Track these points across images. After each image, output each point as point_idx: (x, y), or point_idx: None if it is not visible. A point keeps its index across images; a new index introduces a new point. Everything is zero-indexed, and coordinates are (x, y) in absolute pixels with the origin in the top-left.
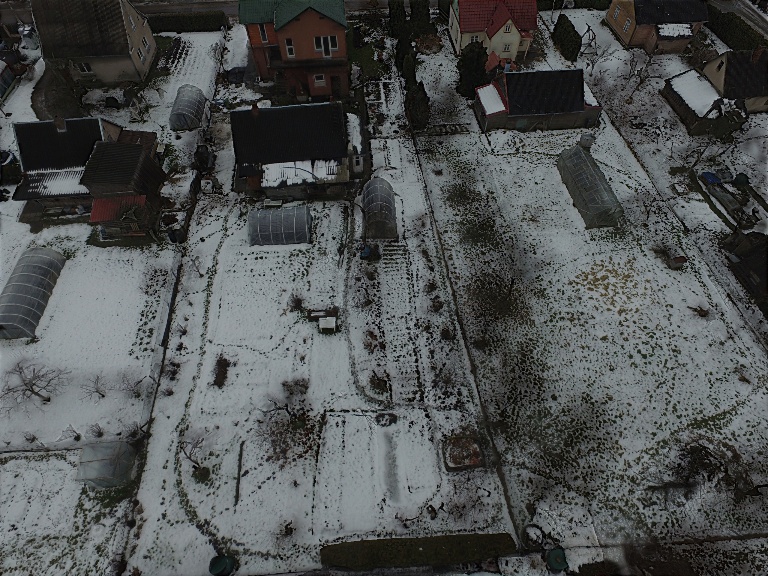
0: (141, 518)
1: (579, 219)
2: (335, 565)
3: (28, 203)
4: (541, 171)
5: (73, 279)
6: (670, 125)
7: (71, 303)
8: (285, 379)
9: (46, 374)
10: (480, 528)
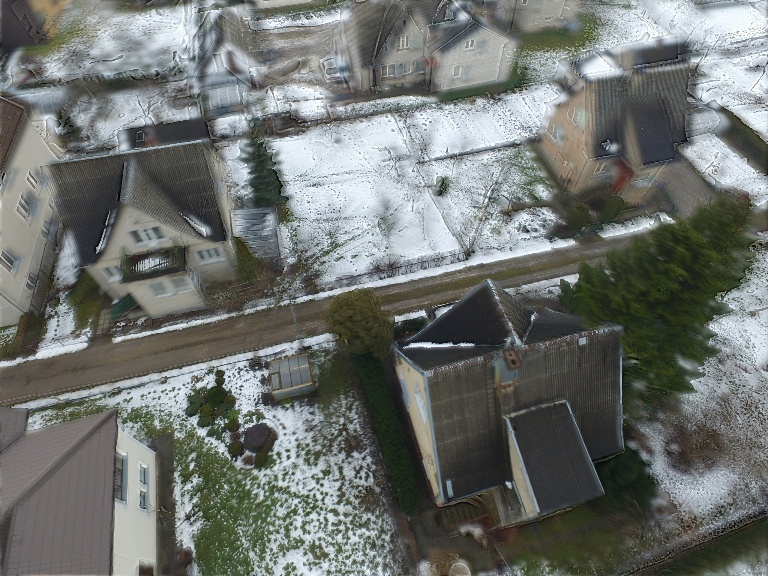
0: None
1: None
2: None
3: None
4: None
5: (727, 6)
6: None
7: (716, 10)
8: (764, 85)
9: (690, 8)
10: None
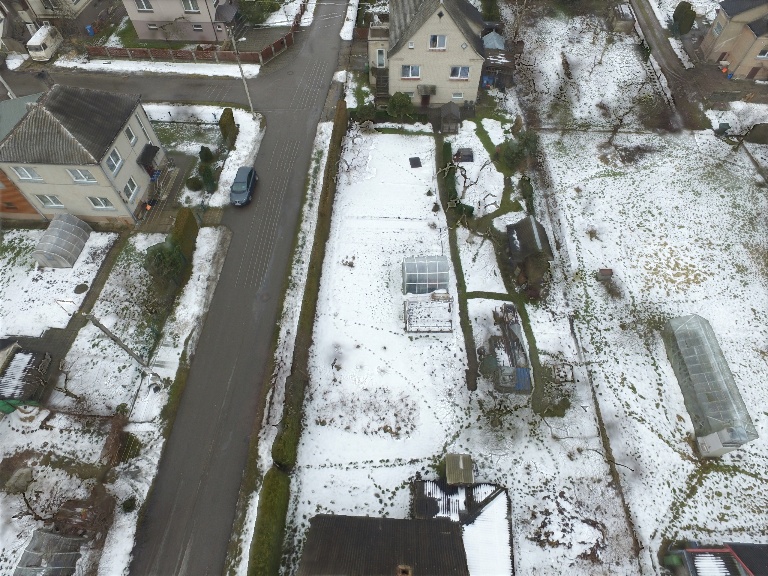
0: None
1: None
2: None
3: None
4: (762, 438)
5: None
6: None
7: None
8: None
9: None
10: (763, 147)
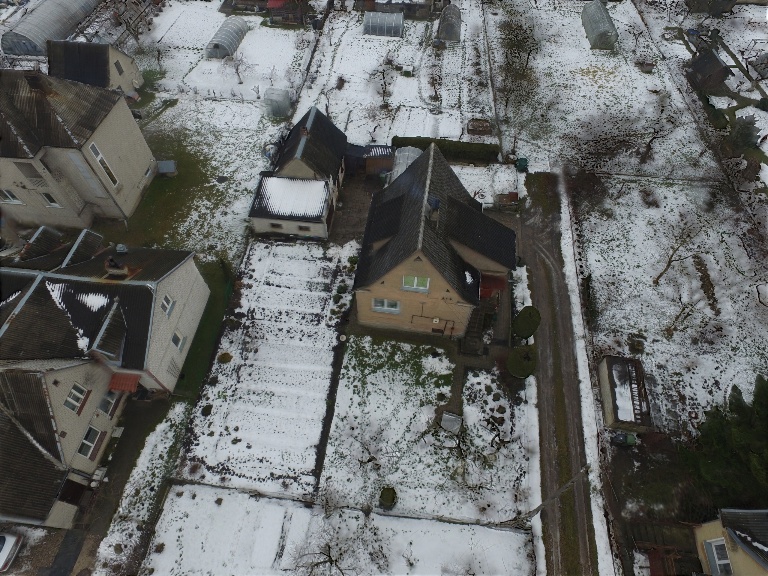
0: None
1: (587, 44)
2: (399, 145)
3: (223, 4)
4: (569, 20)
5: (253, 38)
6: (676, 4)
7: (252, 48)
8: (378, 90)
9: (245, 63)
10: None
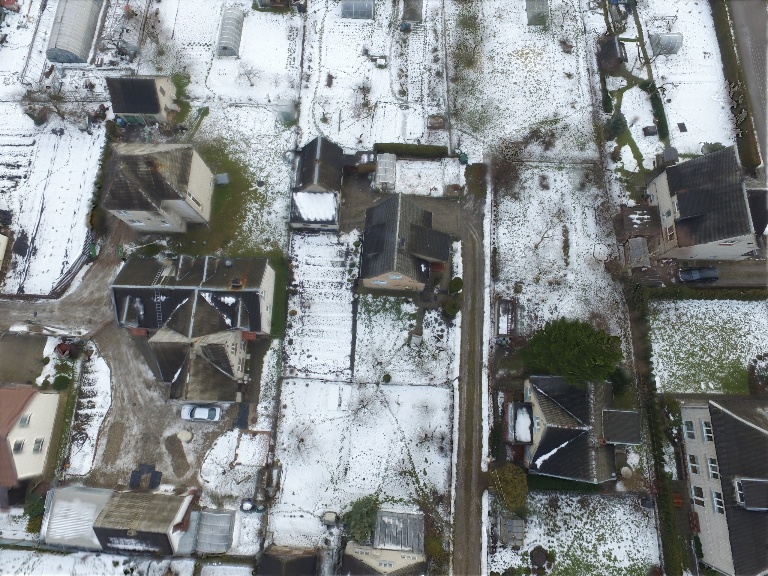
0: (301, 132)
1: (526, 19)
2: (379, 150)
3: None
4: None
5: (250, 28)
6: None
7: (252, 41)
8: None
9: (254, 70)
10: None
